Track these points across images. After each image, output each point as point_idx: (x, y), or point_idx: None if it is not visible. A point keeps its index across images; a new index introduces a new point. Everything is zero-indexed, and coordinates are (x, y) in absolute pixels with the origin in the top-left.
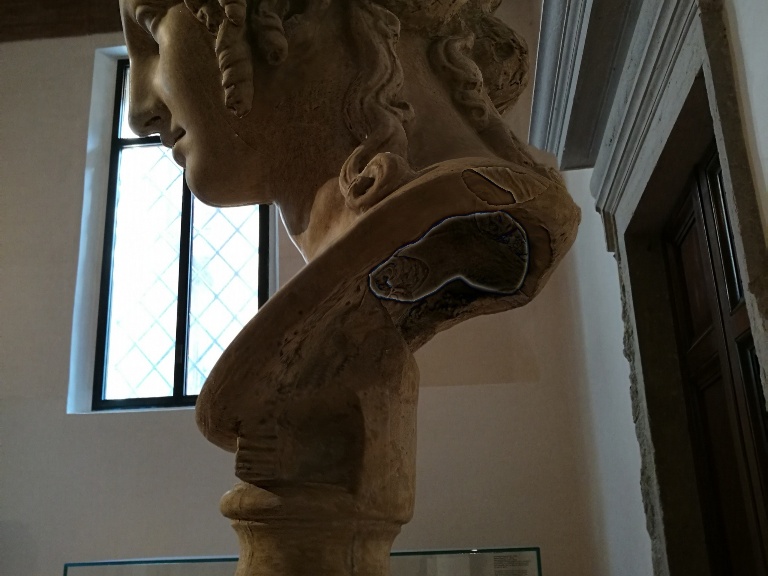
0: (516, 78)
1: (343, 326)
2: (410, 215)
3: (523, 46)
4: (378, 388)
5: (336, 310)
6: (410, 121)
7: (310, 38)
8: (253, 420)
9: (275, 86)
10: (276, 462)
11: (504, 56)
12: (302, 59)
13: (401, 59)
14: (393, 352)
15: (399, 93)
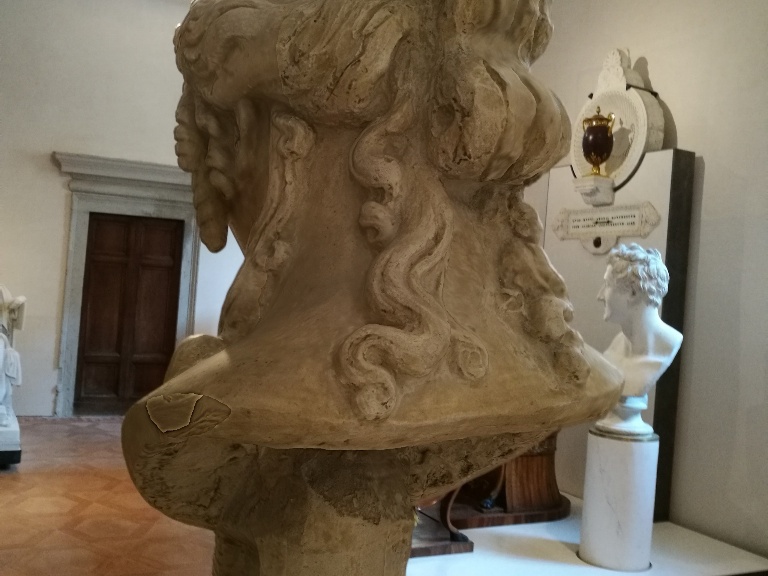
0: (459, 154)
1: (259, 469)
2: (132, 435)
3: (464, 106)
4: (275, 537)
5: (215, 468)
6: (278, 267)
7: (244, 166)
8: (215, 533)
9: (245, 212)
10: (220, 575)
11: (449, 123)
12: (254, 183)
13: (317, 170)
14: (297, 502)
15: (291, 225)
